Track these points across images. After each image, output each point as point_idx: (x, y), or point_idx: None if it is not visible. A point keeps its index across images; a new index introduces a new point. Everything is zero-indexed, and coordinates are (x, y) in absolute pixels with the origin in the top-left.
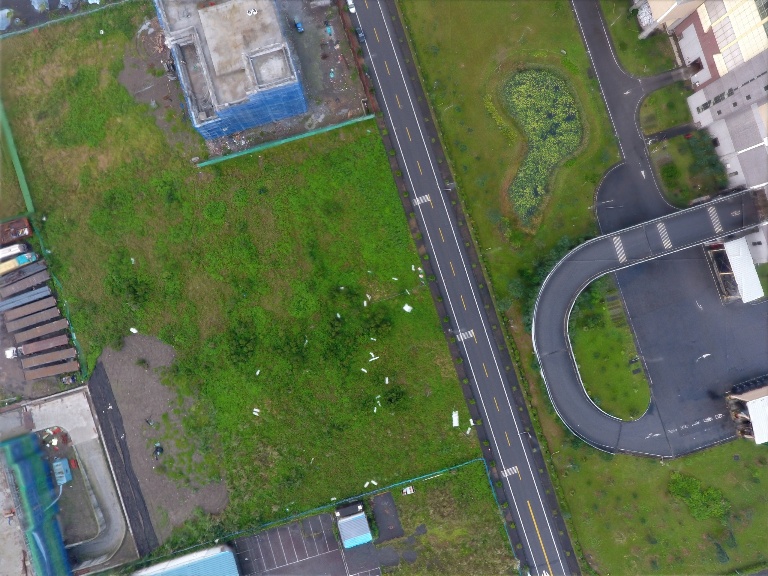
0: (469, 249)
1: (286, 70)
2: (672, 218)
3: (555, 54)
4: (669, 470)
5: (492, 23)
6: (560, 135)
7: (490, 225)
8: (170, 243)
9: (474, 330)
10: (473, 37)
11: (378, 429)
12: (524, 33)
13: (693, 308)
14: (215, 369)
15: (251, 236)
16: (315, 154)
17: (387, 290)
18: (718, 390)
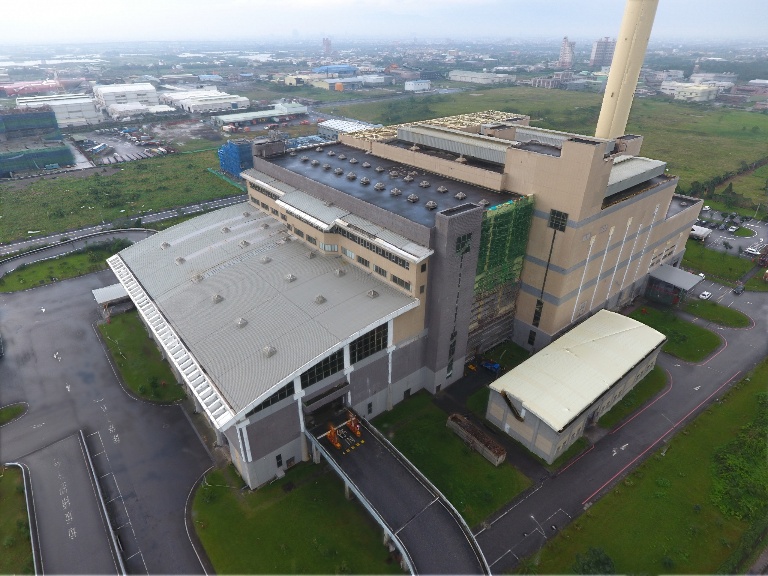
0: None
1: None
2: None
3: None
4: None
5: None
6: None
7: None
8: (168, 169)
9: None
10: None
11: None
12: None
13: None
14: None
15: None
16: None
17: None
18: None
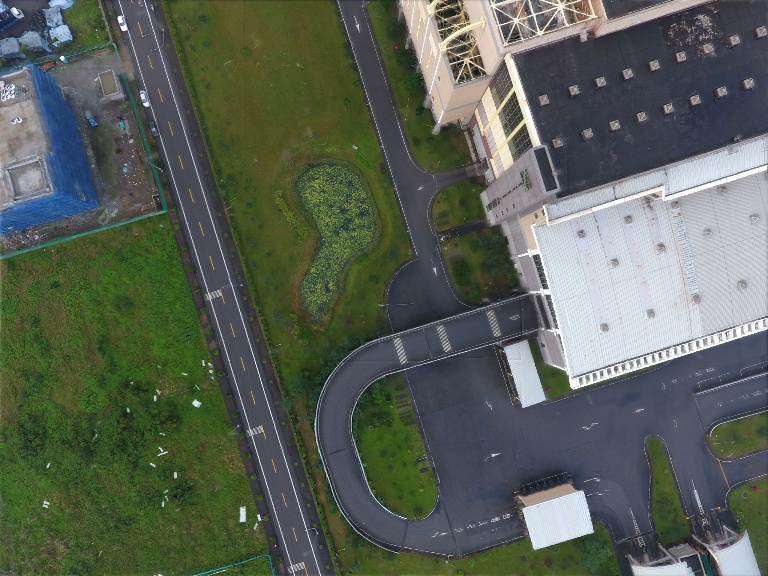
0: (260, 345)
1: (43, 181)
2: (451, 321)
3: (347, 149)
4: (454, 570)
5: (286, 117)
6: (353, 230)
7: (280, 321)
8: None
9: (263, 426)
10: (266, 131)
11: (165, 523)
12: (317, 128)
13: (482, 407)
14: (6, 462)
15: (43, 330)
16: (107, 249)
17: (176, 385)
18: (506, 490)
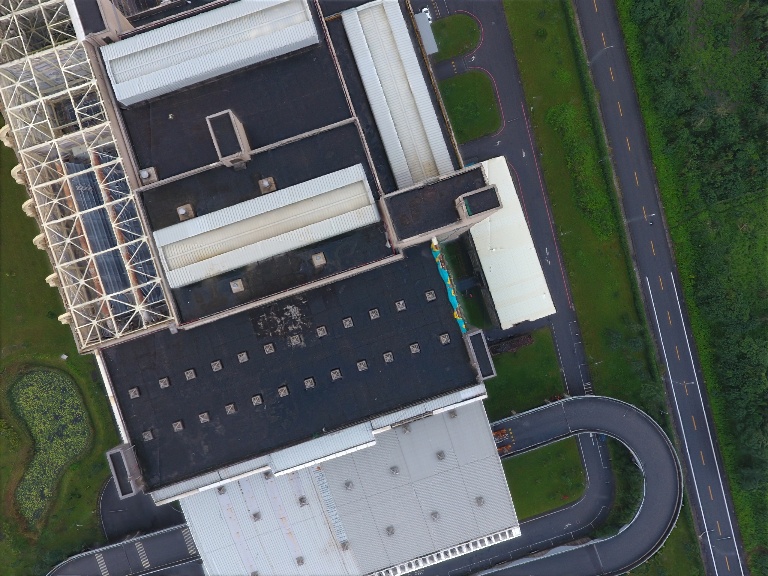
0: None
1: None
2: (149, 538)
3: (58, 358)
4: None
5: None
6: (67, 437)
7: None
8: None
9: None
10: None
11: None
12: (29, 335)
13: None
14: None
15: None
16: None
17: None
18: None
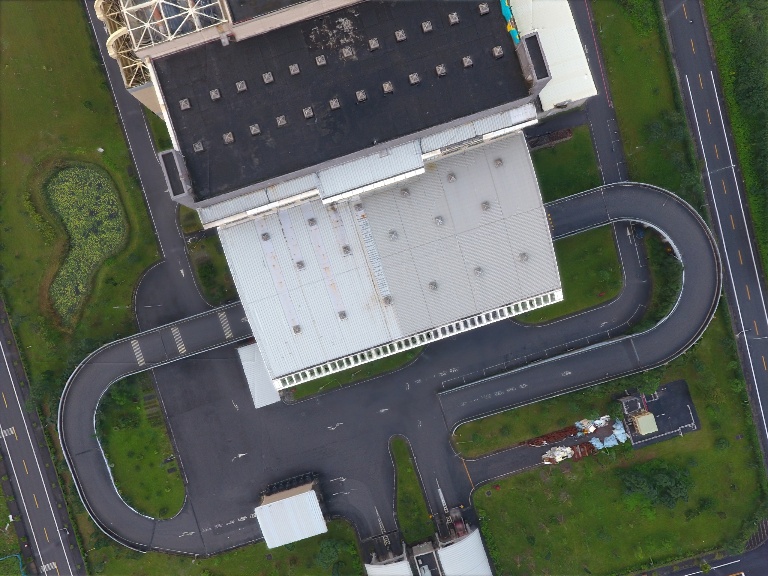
0: (11, 347)
1: None
2: (185, 323)
3: (94, 152)
4: (201, 569)
5: (34, 120)
6: (102, 233)
7: None
8: None
9: (15, 427)
10: (16, 134)
11: None
12: (65, 130)
13: (229, 408)
14: None
15: None
16: None
17: None
18: (253, 490)
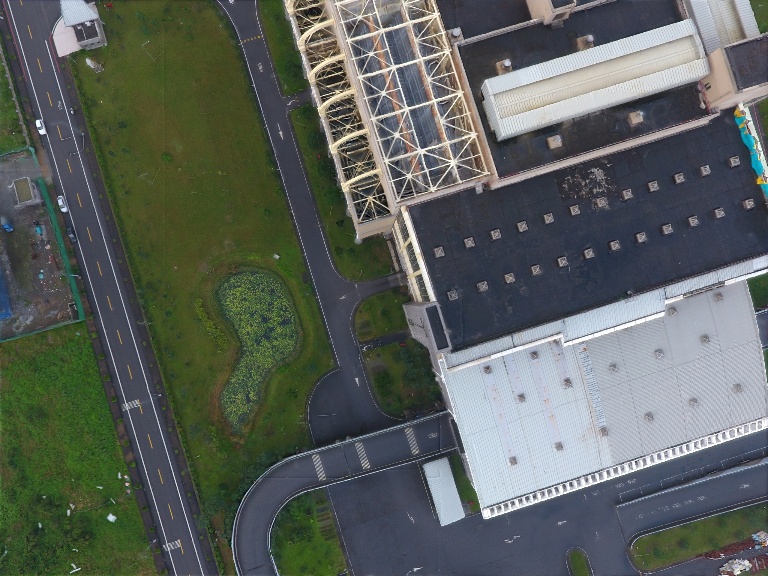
0: (178, 456)
1: None
2: (370, 438)
3: (269, 258)
4: None
5: (207, 224)
6: (274, 339)
7: None
8: None
9: (181, 540)
10: (187, 238)
11: None
12: (239, 235)
13: (404, 520)
14: None
15: None
16: (21, 358)
17: (91, 499)
18: None
